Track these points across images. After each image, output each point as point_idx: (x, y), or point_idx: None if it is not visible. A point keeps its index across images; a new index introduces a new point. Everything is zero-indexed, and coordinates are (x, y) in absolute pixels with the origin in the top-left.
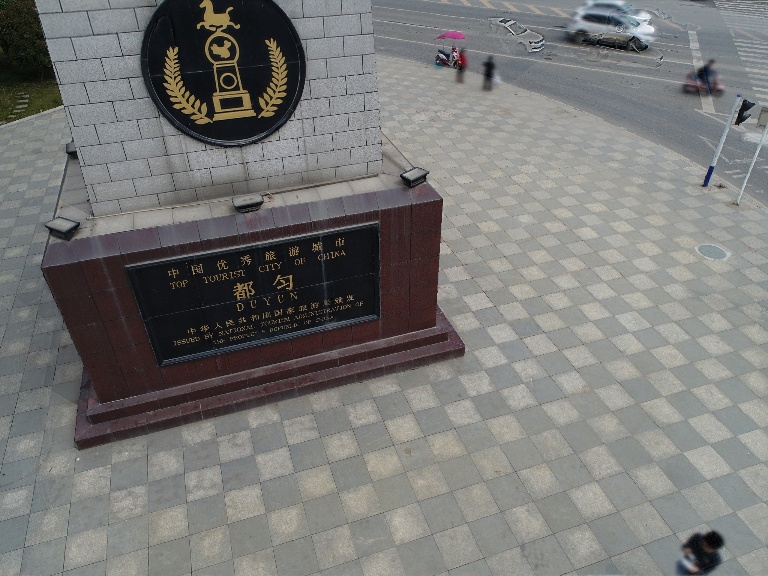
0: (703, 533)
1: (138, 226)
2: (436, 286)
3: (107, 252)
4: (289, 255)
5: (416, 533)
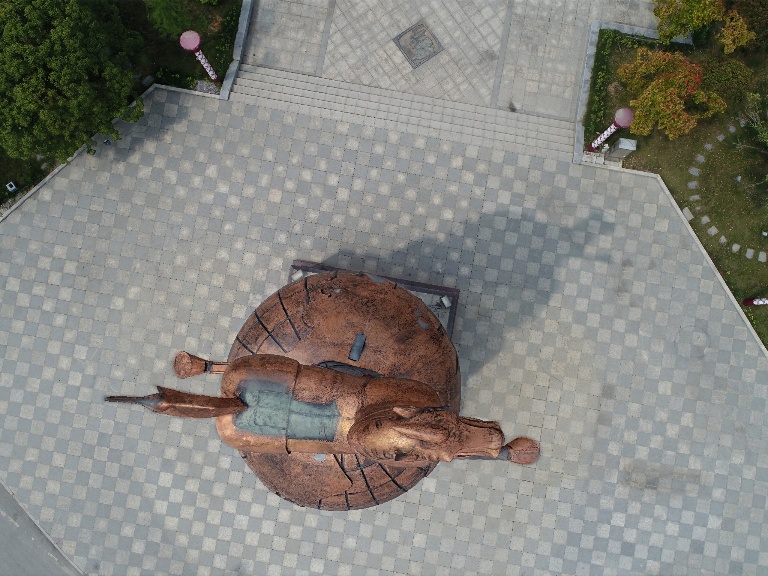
0: (147, 451)
1: None
2: None
3: None
4: None
5: None
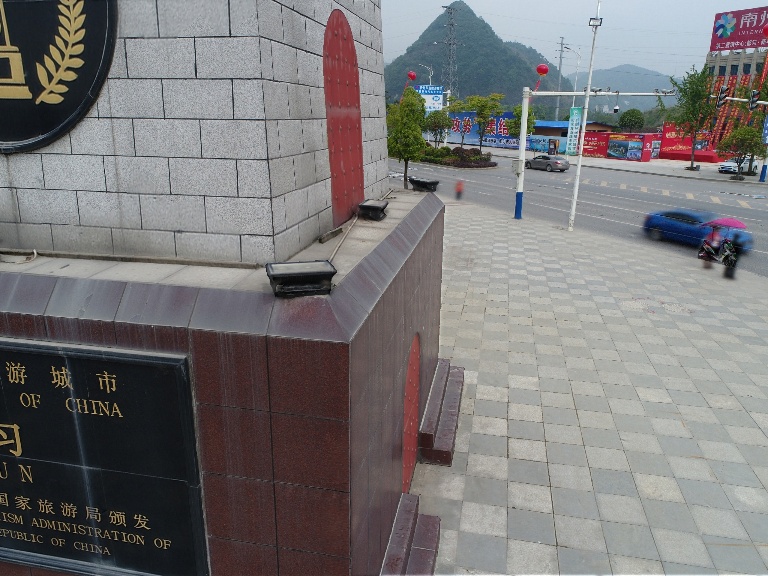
0: None
1: None
2: (346, 571)
3: None
4: (9, 379)
5: None
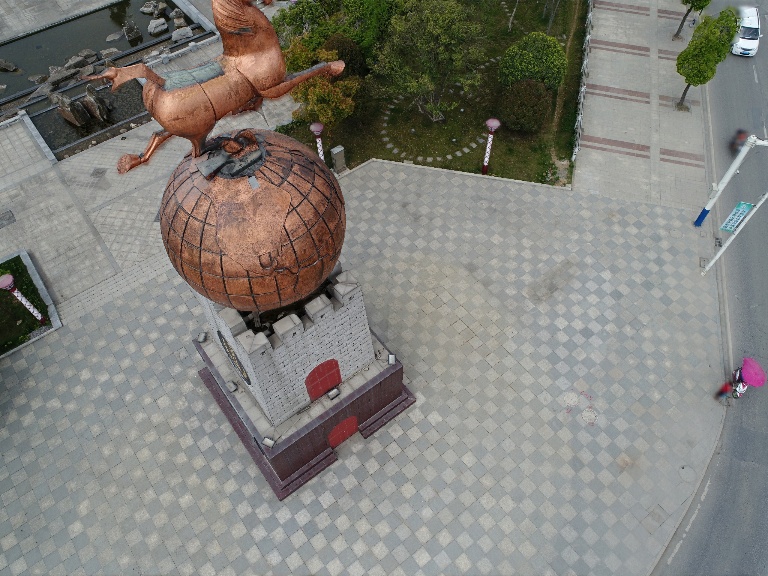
0: None
1: (212, 358)
2: None
3: (202, 355)
4: None
5: (183, 505)
